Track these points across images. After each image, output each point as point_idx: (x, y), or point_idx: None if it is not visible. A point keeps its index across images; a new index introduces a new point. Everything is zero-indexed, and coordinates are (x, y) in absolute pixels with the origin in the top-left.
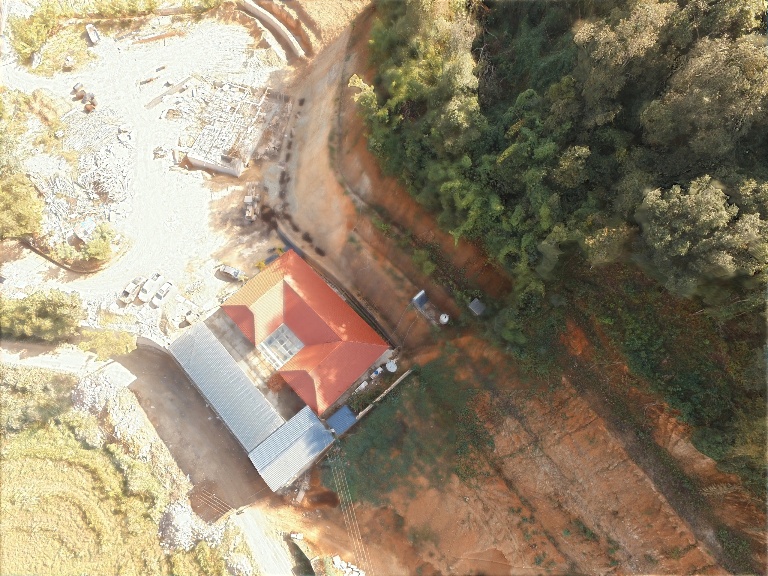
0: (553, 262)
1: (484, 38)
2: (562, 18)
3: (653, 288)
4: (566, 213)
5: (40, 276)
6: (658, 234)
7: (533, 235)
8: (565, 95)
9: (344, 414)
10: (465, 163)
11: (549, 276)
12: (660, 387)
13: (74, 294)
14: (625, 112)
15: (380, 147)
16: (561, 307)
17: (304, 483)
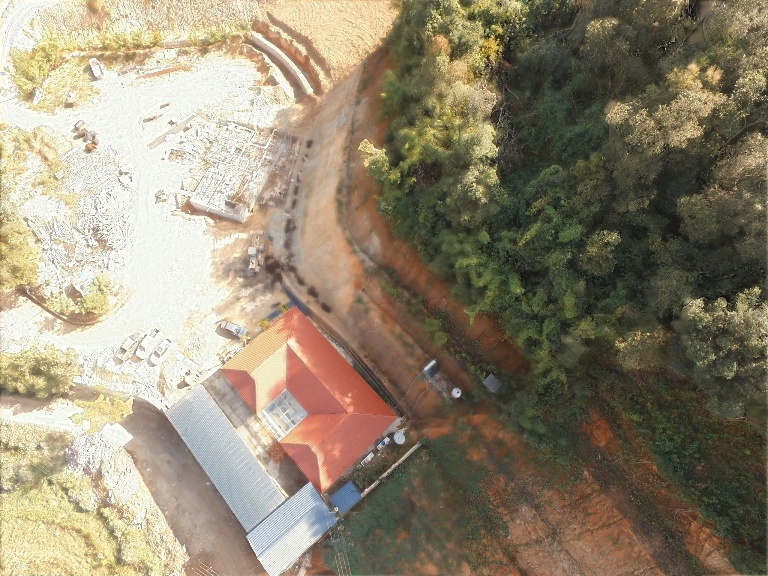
0: (578, 355)
1: (504, 96)
2: (590, 85)
3: (687, 386)
4: (592, 299)
5: (36, 327)
6: (701, 353)
7: (556, 321)
8: (594, 175)
9: (349, 491)
10: (483, 239)
11: (572, 364)
12: (694, 497)
13: (69, 351)
14: (659, 193)
15: (391, 210)
16: (584, 395)
17: (305, 560)
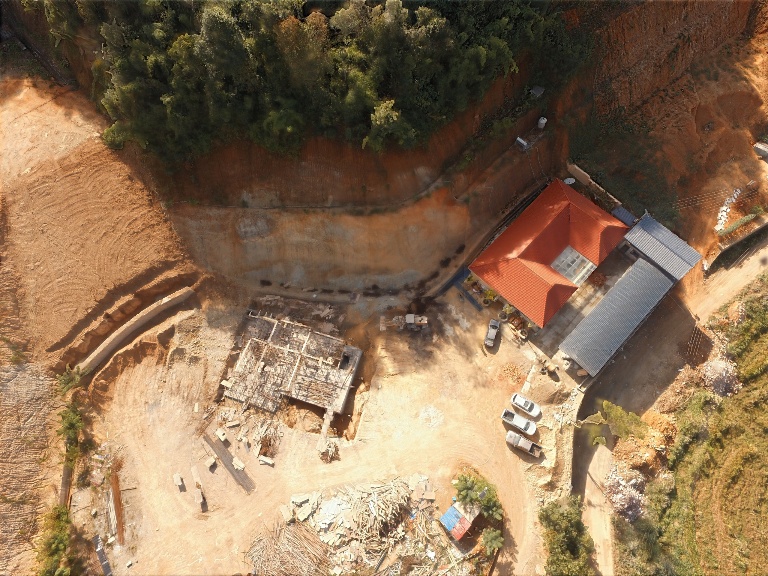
0: None
1: None
2: None
3: None
4: None
5: None
6: None
7: (522, 6)
8: None
9: (620, 213)
10: (467, 36)
11: None
12: None
13: (547, 510)
14: None
15: None
16: None
17: None
